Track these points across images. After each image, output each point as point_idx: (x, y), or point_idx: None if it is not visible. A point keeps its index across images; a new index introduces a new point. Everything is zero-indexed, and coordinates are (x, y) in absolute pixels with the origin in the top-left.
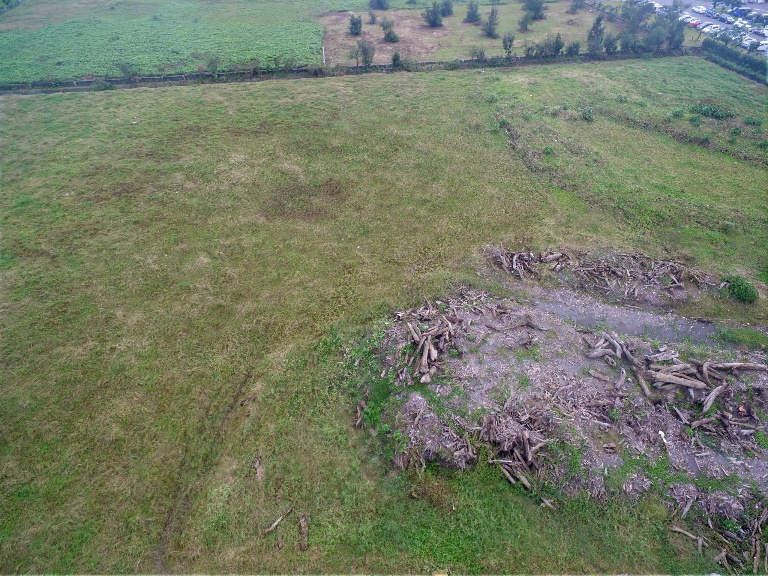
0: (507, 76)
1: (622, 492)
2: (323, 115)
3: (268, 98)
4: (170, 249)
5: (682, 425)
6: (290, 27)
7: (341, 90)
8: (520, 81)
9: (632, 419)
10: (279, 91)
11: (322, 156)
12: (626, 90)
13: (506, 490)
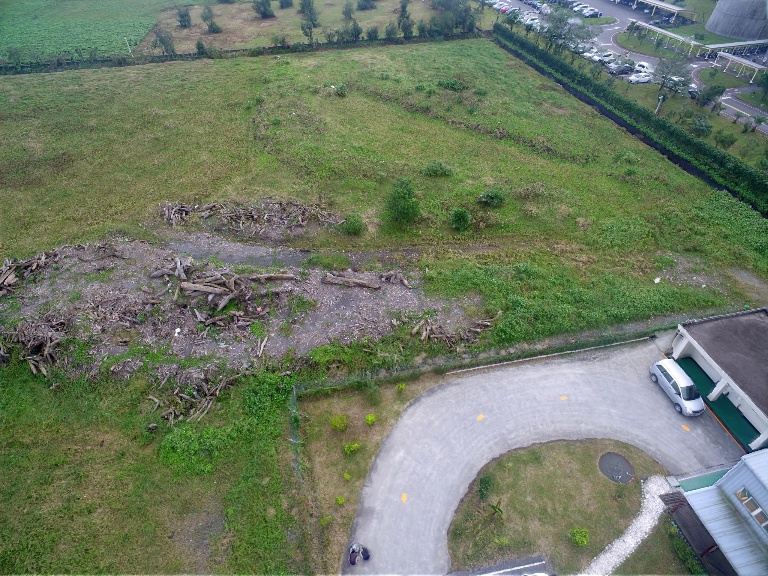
0: (298, 60)
1: (109, 372)
2: (100, 99)
3: (57, 86)
4: None
5: (198, 323)
6: (125, 21)
7: (132, 77)
8: (308, 64)
9: (156, 320)
10: (72, 79)
11: (72, 135)
12: (397, 69)
13: (29, 380)
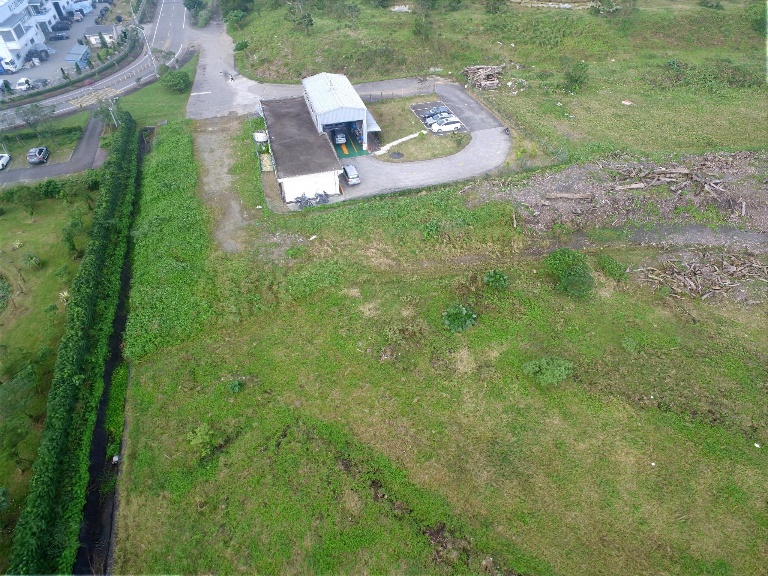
0: None
1: None
2: None
3: None
4: None
5: None
6: None
7: None
8: None
9: None
10: None
11: None
12: None
13: None
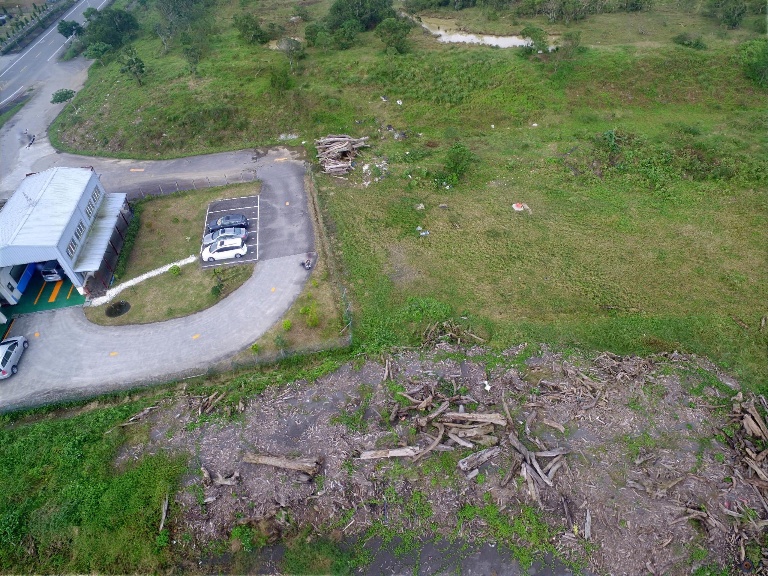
0: None
1: None
2: None
3: None
4: None
5: None
6: None
7: None
8: None
9: (517, 392)
10: None
11: None
12: None
13: None
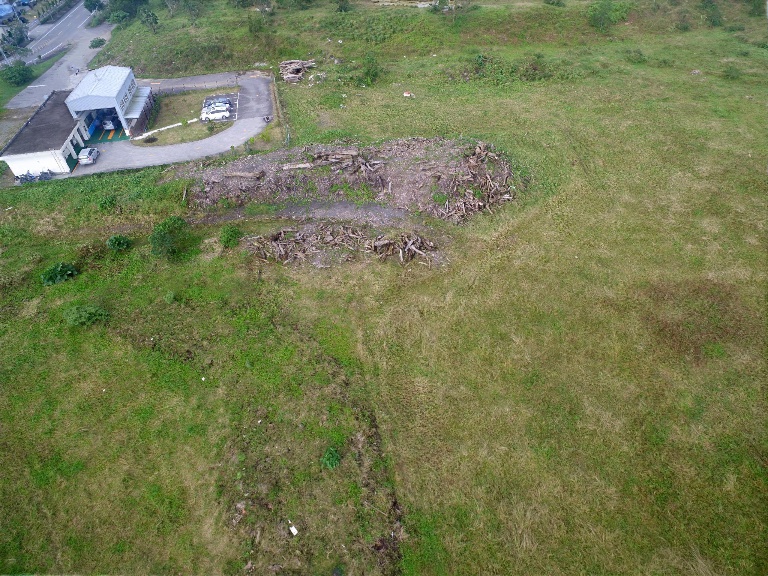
0: None
1: None
2: None
3: None
4: (762, 239)
5: None
6: None
7: None
8: None
9: None
10: None
11: None
12: None
13: None
